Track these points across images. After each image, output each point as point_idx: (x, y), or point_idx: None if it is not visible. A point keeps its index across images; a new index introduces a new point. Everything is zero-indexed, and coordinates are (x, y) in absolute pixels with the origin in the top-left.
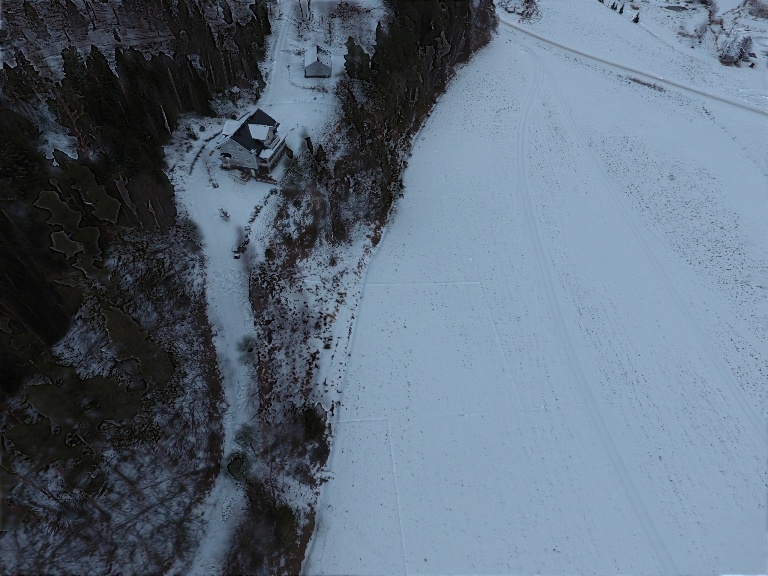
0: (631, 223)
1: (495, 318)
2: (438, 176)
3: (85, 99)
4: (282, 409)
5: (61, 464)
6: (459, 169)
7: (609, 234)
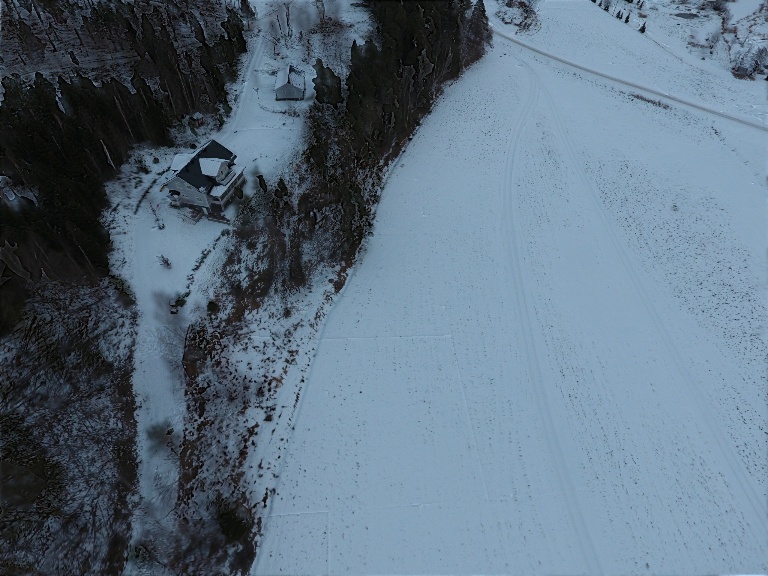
0: (627, 263)
1: (465, 380)
2: (415, 208)
3: (17, 134)
4: (205, 501)
5: None
6: (439, 200)
7: (601, 276)
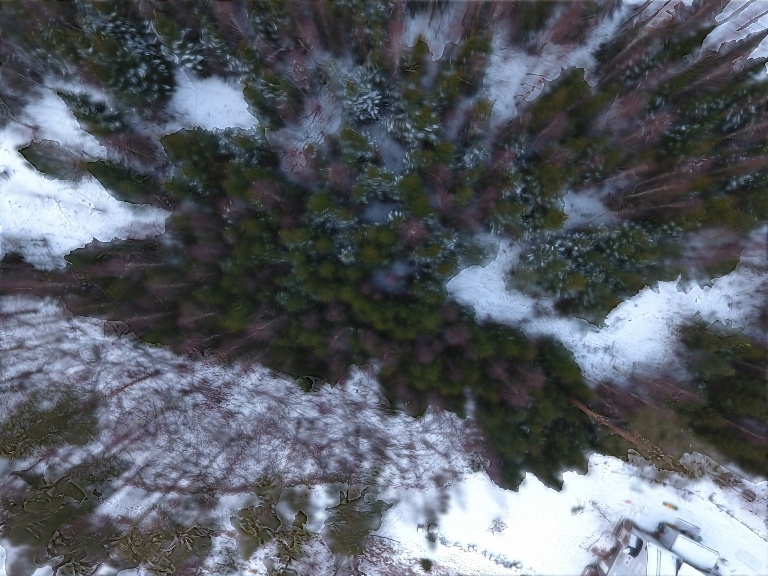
0: None
1: None
2: None
3: None
4: None
5: (135, 387)
6: None
7: None
